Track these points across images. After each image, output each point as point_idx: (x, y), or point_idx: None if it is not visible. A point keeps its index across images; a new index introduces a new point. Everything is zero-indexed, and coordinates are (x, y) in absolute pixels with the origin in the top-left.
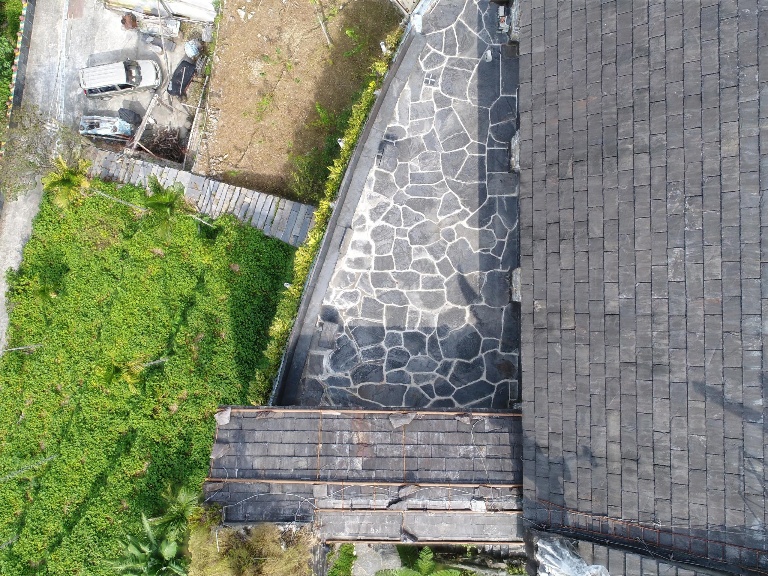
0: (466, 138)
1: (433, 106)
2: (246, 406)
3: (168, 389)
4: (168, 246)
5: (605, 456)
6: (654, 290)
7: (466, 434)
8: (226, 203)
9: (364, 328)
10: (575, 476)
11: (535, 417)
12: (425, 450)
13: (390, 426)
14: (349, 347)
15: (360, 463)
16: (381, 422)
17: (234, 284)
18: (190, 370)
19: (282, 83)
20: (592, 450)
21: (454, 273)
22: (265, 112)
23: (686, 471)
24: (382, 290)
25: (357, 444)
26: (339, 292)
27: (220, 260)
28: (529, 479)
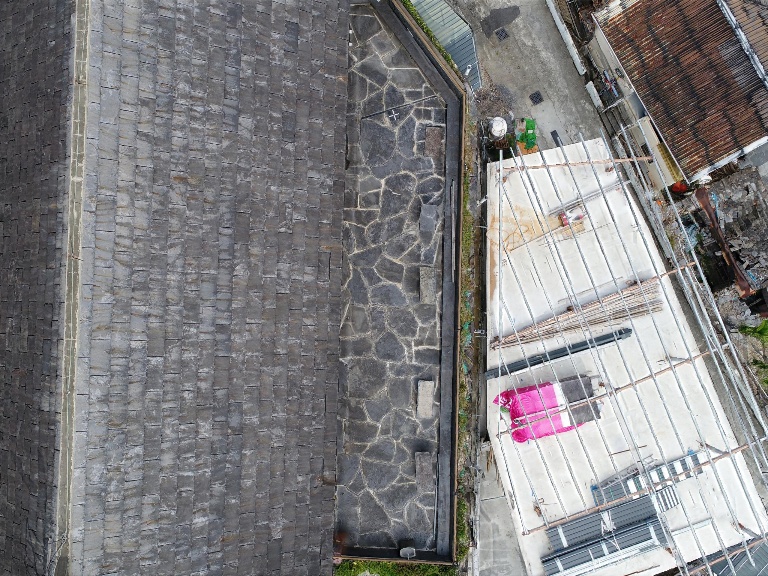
0: None
1: None
2: None
3: None
4: None
5: None
6: None
7: None
8: None
9: None
10: None
11: None
12: None
13: None
14: None
15: None
16: None
17: None
18: None
19: None
20: None
21: None
22: None
23: (5, 538)
24: None
25: None
26: None
27: None
28: None
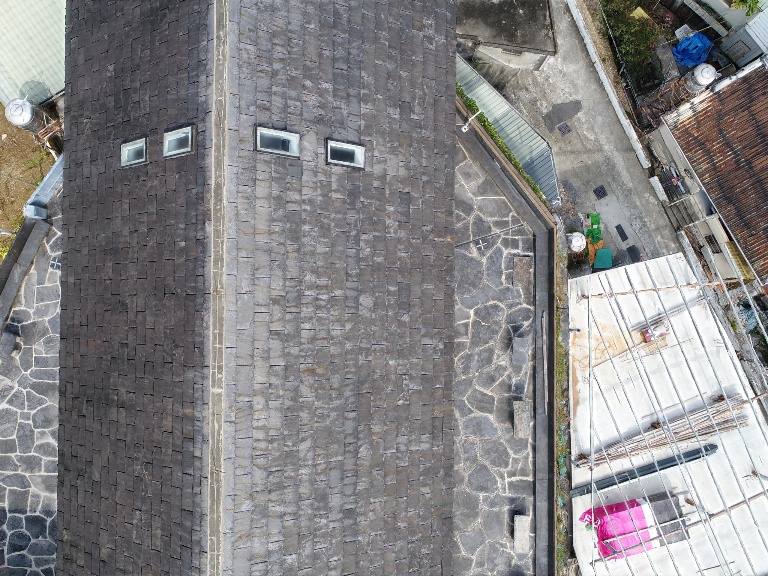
0: None
1: (58, 290)
2: None
3: None
4: None
5: None
6: (125, 547)
7: None
8: None
9: None
10: None
11: None
12: None
13: None
14: None
15: None
16: None
17: None
18: None
19: None
20: None
21: None
22: None
23: None
24: (5, 473)
25: None
26: None
27: None
28: None
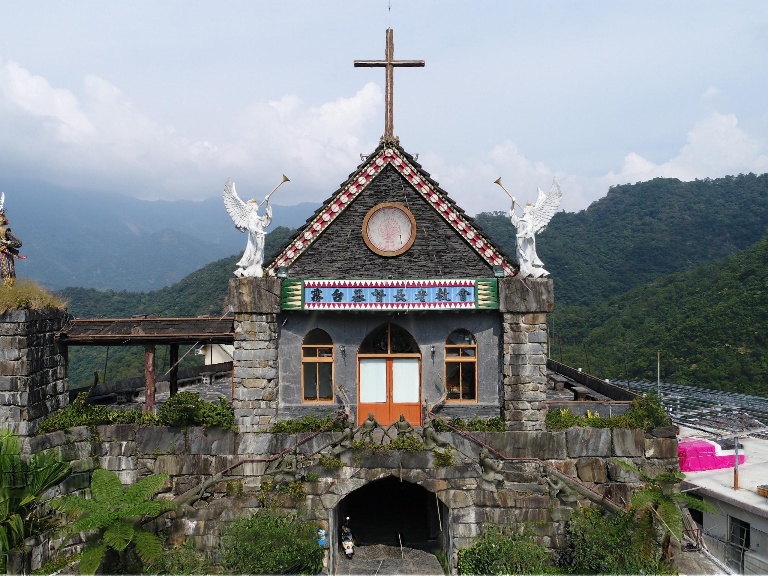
0: None
1: None
2: None
3: None
4: None
5: None
6: None
7: None
8: None
9: None
10: None
11: None
12: None
13: None
14: None
15: None
16: None
17: None
18: None
19: None
20: None
21: None
22: None
23: None
24: None
25: None
26: None
27: None
28: None
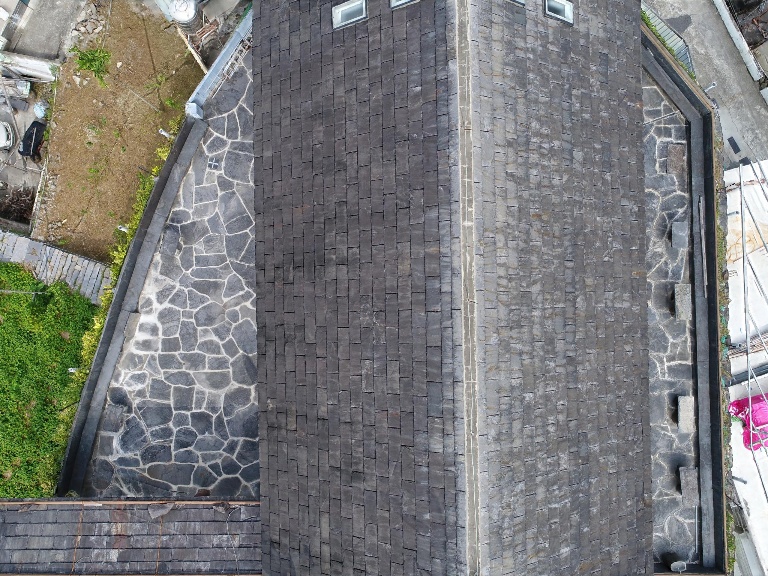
0: (249, 221)
1: (217, 189)
2: (11, 499)
3: (1, 457)
4: (7, 312)
5: (320, 556)
6: (352, 399)
7: (221, 523)
8: (59, 270)
9: (152, 409)
10: (299, 573)
11: (269, 513)
12: (180, 540)
13: (149, 516)
14: (138, 428)
15: (116, 555)
16: (140, 513)
17: (64, 352)
18: (23, 437)
19: (117, 148)
20: (310, 549)
21: (239, 353)
22: (101, 177)
23: None
24: (169, 371)
25: (115, 536)
26: (128, 374)
27: (49, 329)
28: (266, 572)
